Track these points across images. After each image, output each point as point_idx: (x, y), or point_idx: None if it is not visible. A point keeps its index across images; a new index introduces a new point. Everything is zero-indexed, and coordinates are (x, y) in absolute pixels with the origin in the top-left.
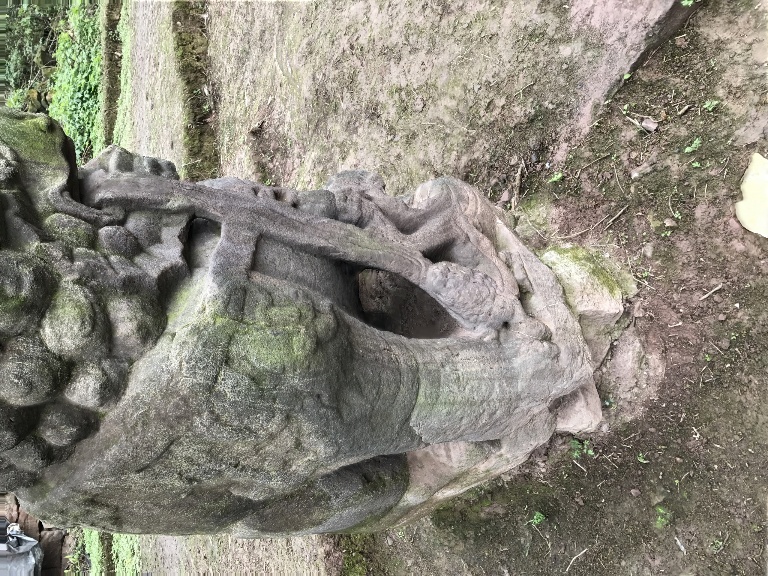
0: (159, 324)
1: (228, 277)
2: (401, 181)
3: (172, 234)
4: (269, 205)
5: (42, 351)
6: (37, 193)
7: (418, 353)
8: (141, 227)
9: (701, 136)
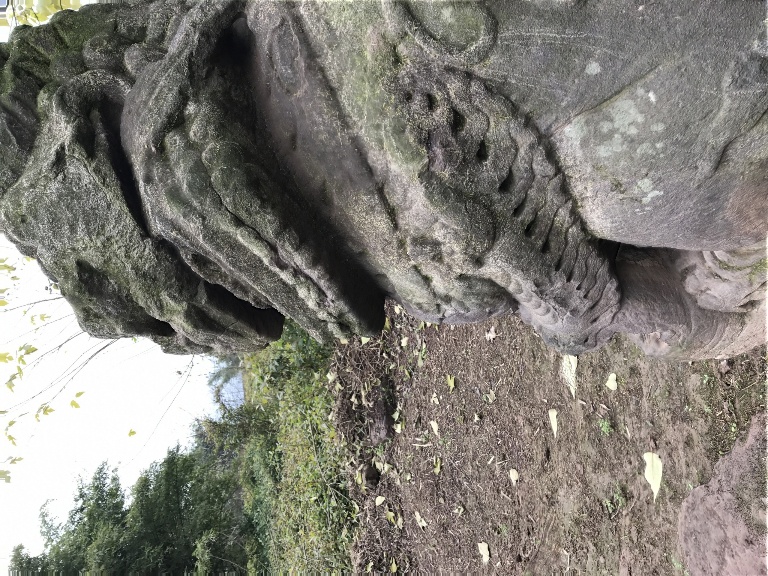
0: None
1: None
2: None
3: None
4: None
5: None
6: None
7: None
8: None
9: (711, 388)
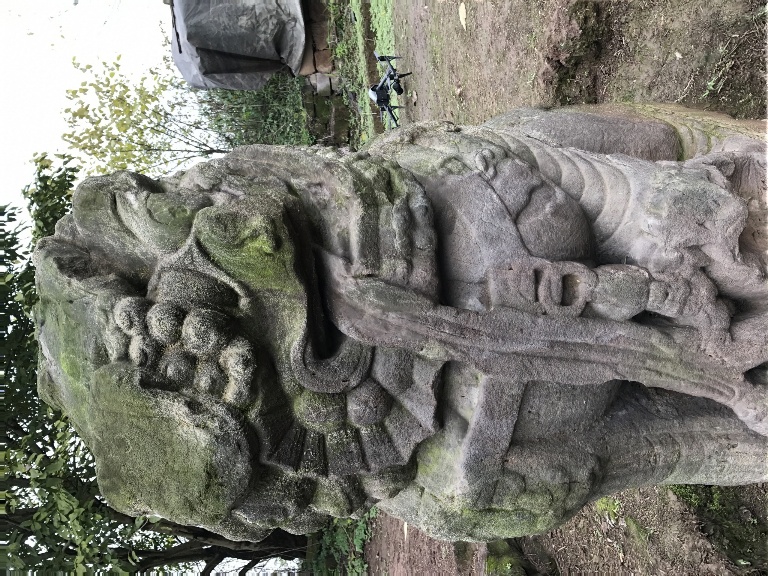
0: (409, 479)
1: (481, 474)
2: None
3: (425, 378)
4: (548, 338)
5: (311, 515)
6: (278, 351)
7: (686, 446)
8: (391, 378)
9: None
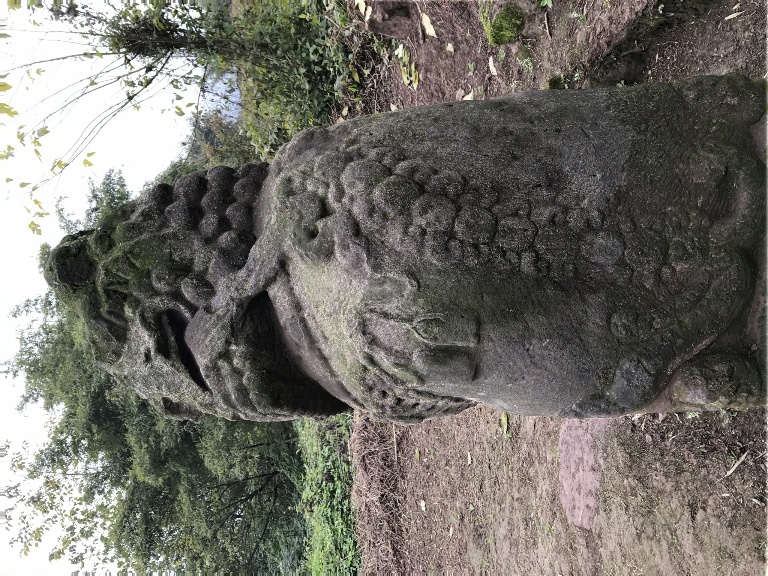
0: None
1: None
2: (729, 569)
3: None
4: None
5: None
6: None
7: None
8: None
9: None
